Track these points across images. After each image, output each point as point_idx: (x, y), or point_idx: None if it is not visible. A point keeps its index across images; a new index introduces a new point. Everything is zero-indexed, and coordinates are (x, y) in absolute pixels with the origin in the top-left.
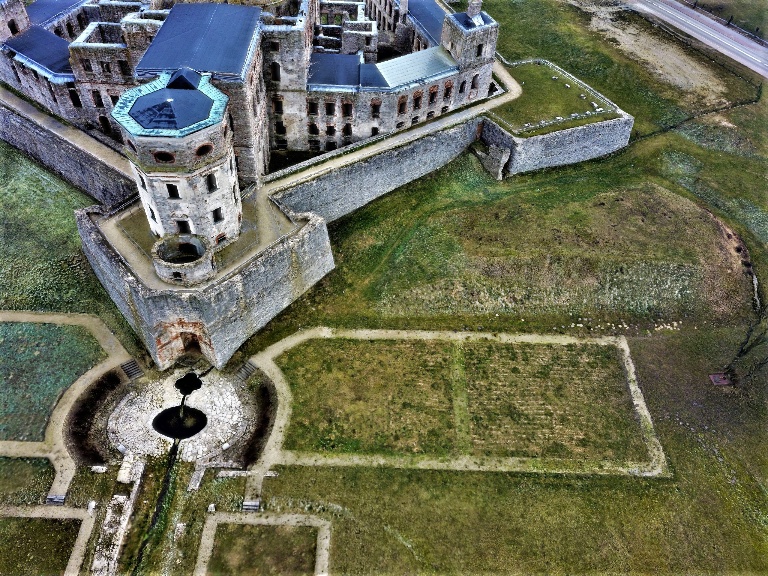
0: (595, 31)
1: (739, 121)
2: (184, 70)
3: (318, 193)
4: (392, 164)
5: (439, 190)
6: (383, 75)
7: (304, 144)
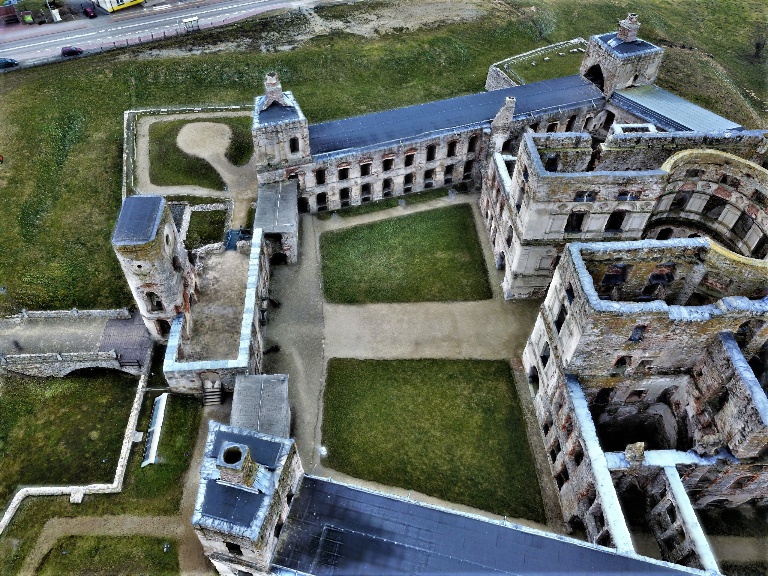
0: (380, 35)
1: (525, 3)
2: None
3: None
4: None
5: None
6: None
7: None
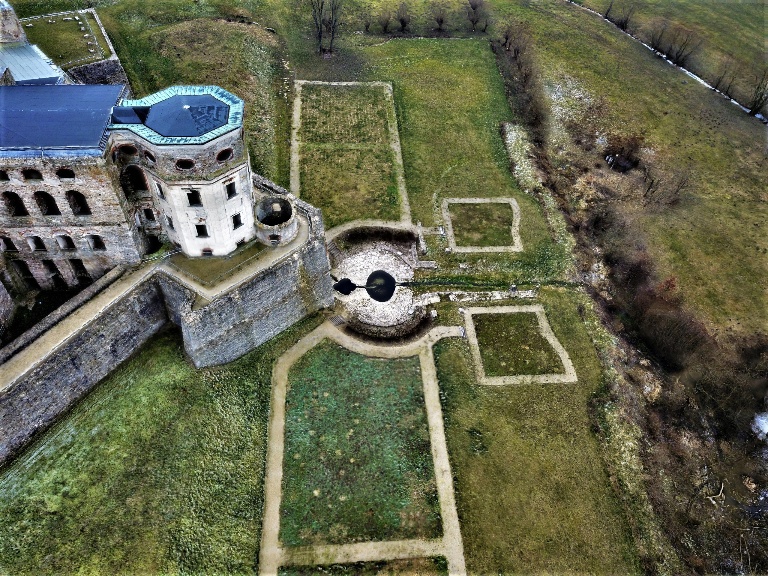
0: None
1: None
2: (121, 107)
3: None
4: None
5: None
6: (33, 79)
7: None
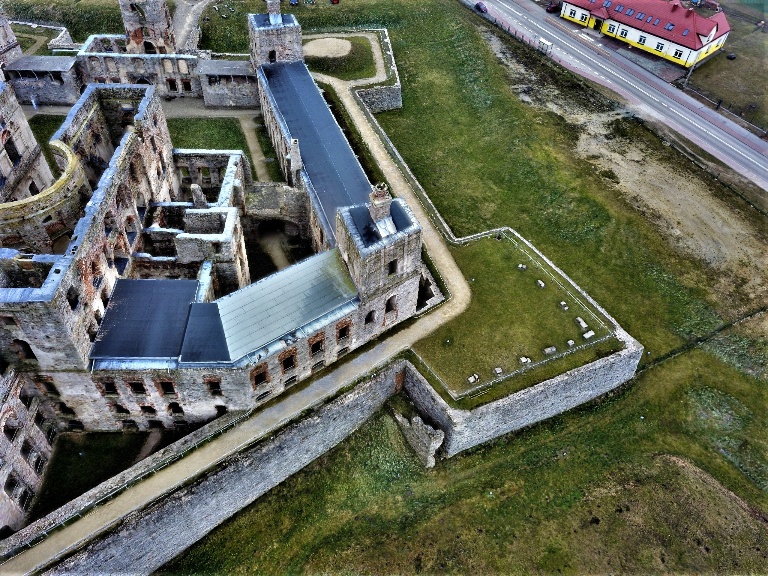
0: (584, 159)
1: None
2: None
3: (96, 567)
4: (243, 477)
5: (331, 492)
6: (225, 330)
7: (110, 424)
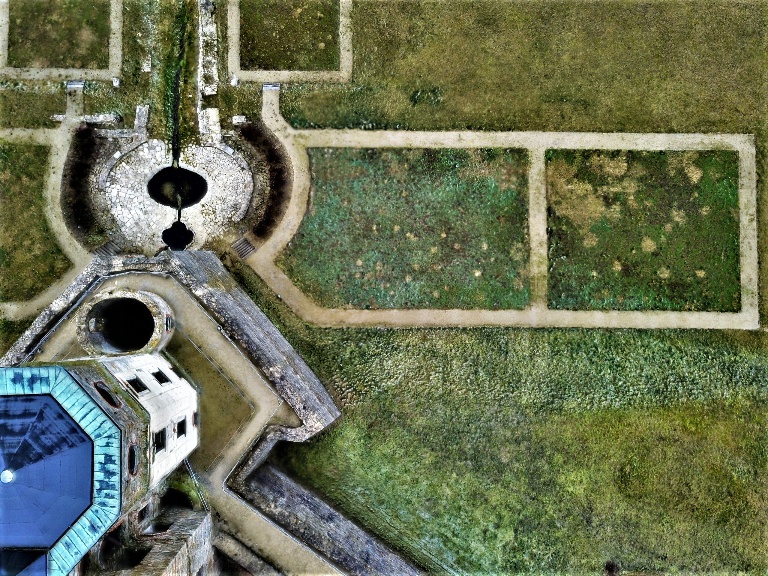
0: None
1: None
2: None
3: None
4: None
5: None
6: None
7: None
